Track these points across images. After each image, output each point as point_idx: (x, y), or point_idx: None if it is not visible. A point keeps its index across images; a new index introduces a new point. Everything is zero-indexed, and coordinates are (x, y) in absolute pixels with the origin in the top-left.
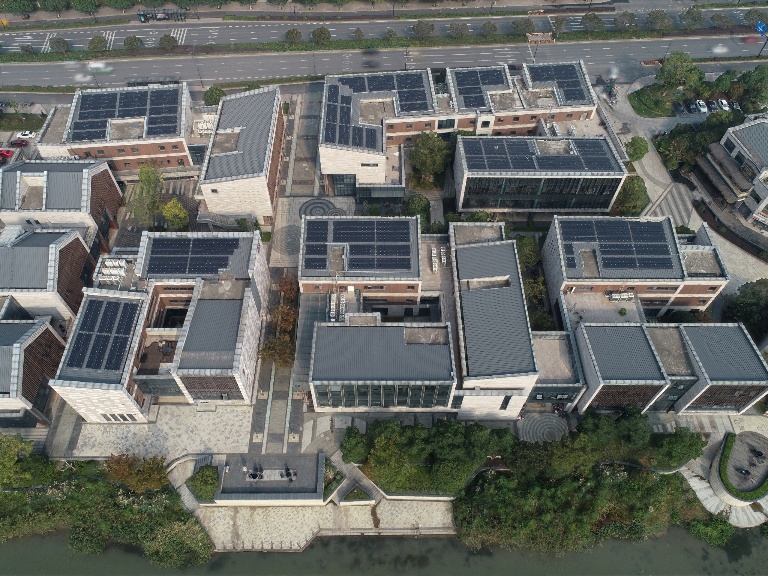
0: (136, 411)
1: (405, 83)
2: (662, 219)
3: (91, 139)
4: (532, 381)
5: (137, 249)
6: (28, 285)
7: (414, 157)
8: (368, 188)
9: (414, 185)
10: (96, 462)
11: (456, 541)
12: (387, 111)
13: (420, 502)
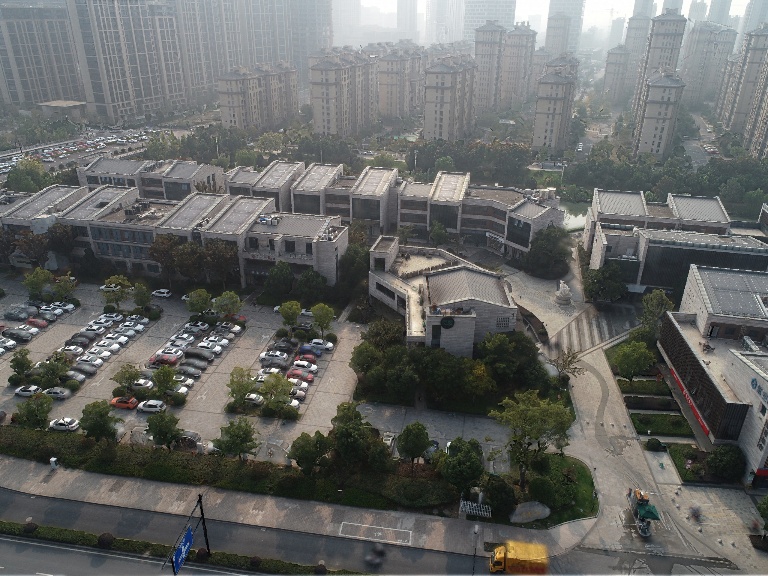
0: None
1: None
2: None
3: None
4: None
5: None
6: None
7: None
8: None
9: None
10: None
11: None
12: None
13: None
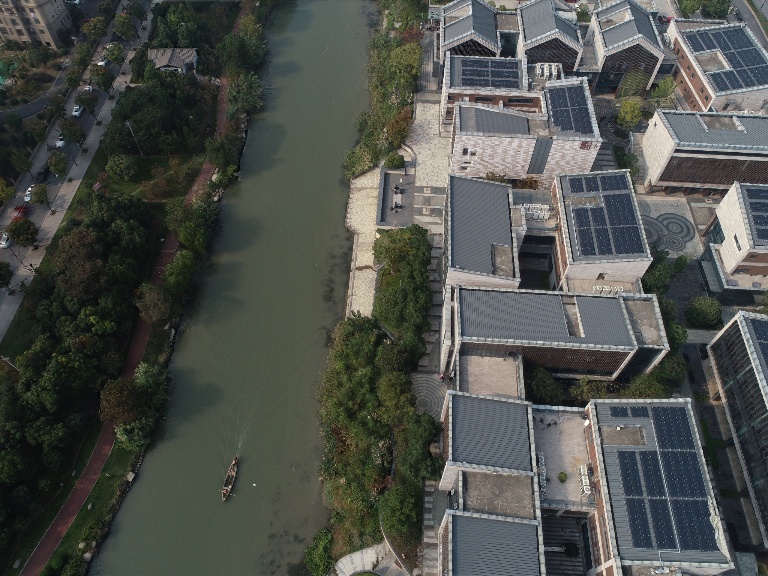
0: (442, 116)
1: None
2: (724, 552)
3: (691, 45)
4: None
5: None
6: (527, 34)
7: None
8: (712, 256)
9: None
10: (412, 113)
11: None
12: None
13: None
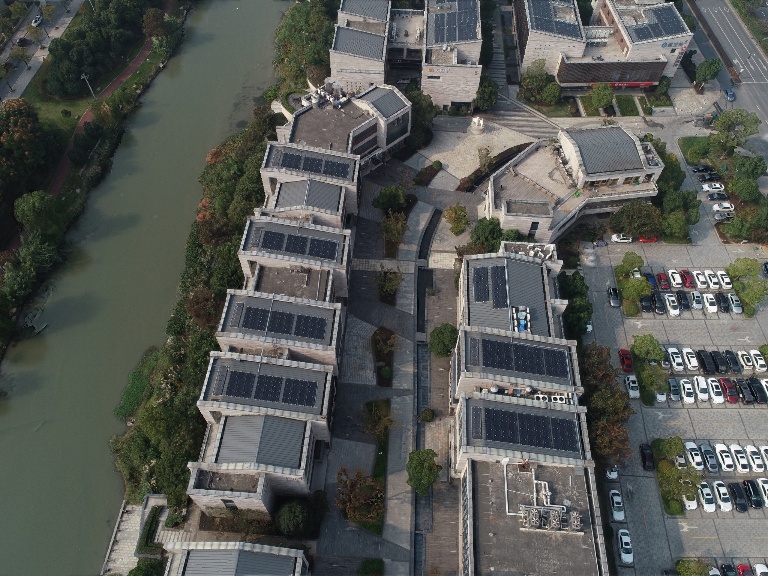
0: None
1: None
2: None
3: None
4: None
5: None
6: None
7: None
8: None
9: None
10: None
11: None
12: None
13: None
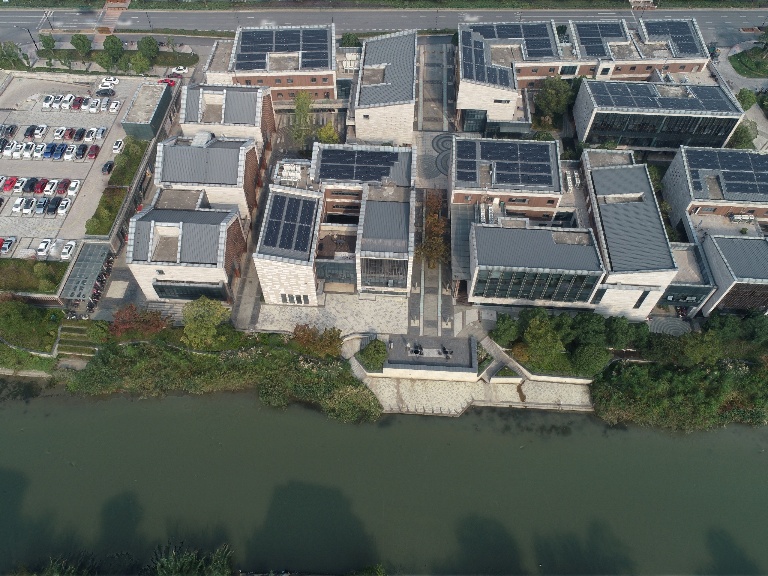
0: (313, 292)
1: (531, 32)
2: None
3: (253, 69)
4: (669, 278)
5: (304, 160)
6: (220, 181)
7: (540, 98)
8: (498, 123)
9: (535, 126)
10: (277, 334)
11: (594, 417)
12: (515, 56)
13: (560, 384)
